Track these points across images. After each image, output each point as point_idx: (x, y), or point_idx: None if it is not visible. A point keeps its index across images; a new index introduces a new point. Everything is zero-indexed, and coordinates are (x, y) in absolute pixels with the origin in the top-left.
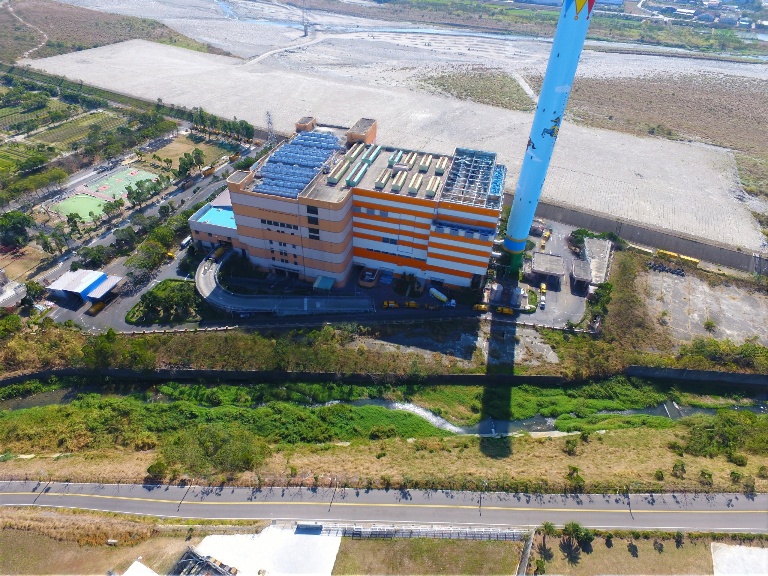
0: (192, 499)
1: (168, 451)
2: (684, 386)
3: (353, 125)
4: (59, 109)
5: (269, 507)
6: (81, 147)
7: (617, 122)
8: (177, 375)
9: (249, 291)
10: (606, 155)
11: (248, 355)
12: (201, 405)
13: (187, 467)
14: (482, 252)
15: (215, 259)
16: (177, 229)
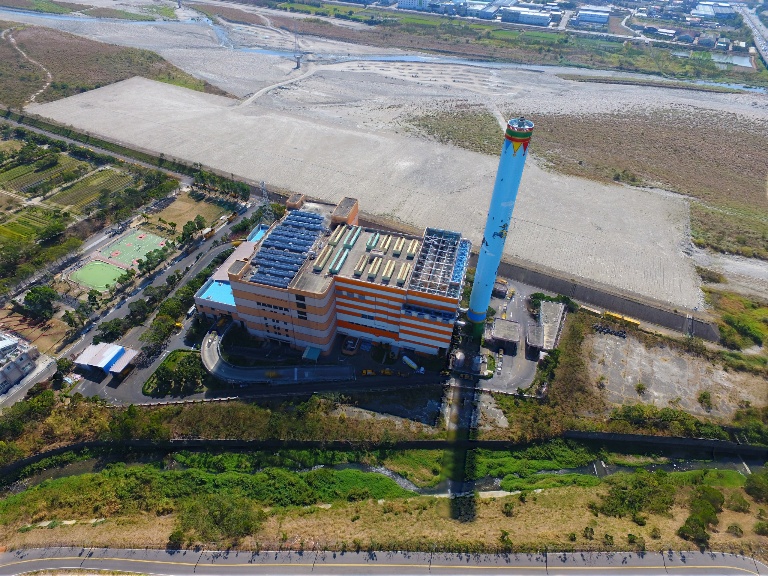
0: (205, 562)
1: (184, 519)
2: (612, 446)
3: (337, 206)
4: (70, 166)
5: (265, 568)
6: (93, 210)
7: (586, 167)
8: (188, 444)
9: (247, 363)
10: (572, 206)
11: (247, 425)
12: (209, 471)
13: (200, 534)
14: (445, 331)
15: (217, 332)
16: (183, 298)
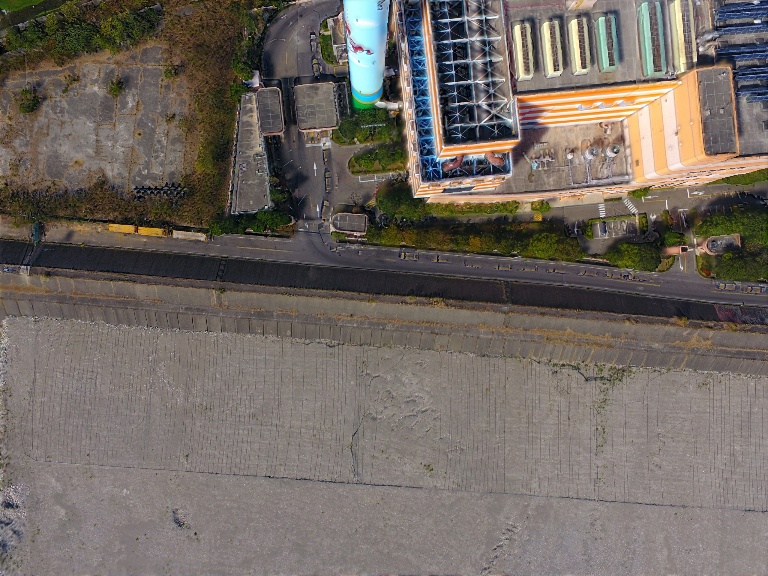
0: None
1: None
2: None
3: None
4: None
5: None
6: None
7: None
8: None
9: None
10: None
11: None
12: None
13: None
14: None
15: None
16: None
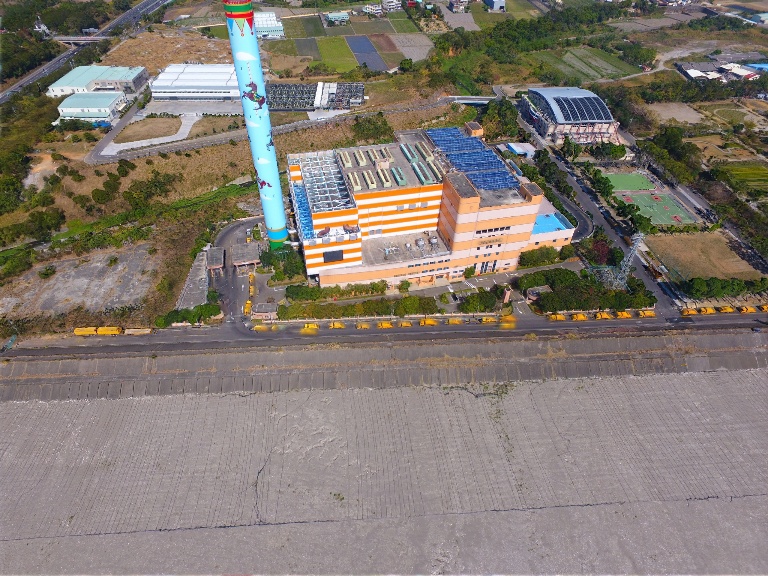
0: None
1: None
2: None
3: None
4: None
5: None
6: None
7: None
8: None
9: None
10: None
11: None
12: None
13: None
14: None
15: None
16: None
